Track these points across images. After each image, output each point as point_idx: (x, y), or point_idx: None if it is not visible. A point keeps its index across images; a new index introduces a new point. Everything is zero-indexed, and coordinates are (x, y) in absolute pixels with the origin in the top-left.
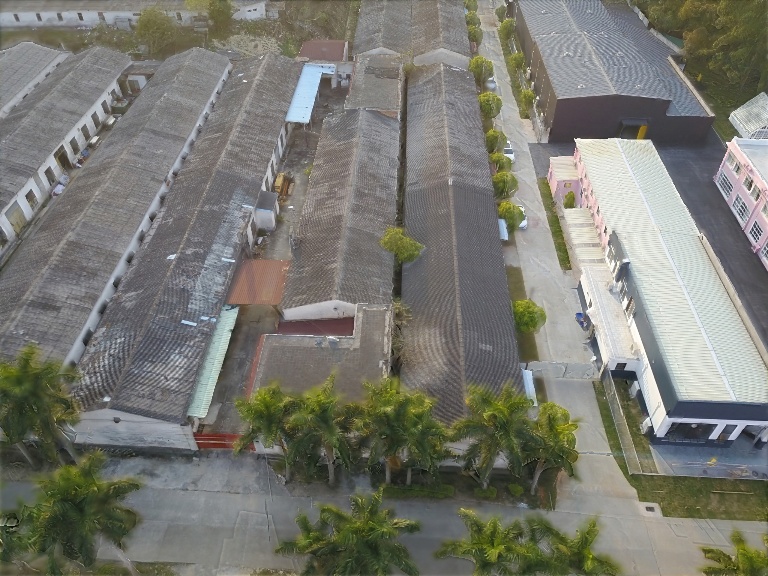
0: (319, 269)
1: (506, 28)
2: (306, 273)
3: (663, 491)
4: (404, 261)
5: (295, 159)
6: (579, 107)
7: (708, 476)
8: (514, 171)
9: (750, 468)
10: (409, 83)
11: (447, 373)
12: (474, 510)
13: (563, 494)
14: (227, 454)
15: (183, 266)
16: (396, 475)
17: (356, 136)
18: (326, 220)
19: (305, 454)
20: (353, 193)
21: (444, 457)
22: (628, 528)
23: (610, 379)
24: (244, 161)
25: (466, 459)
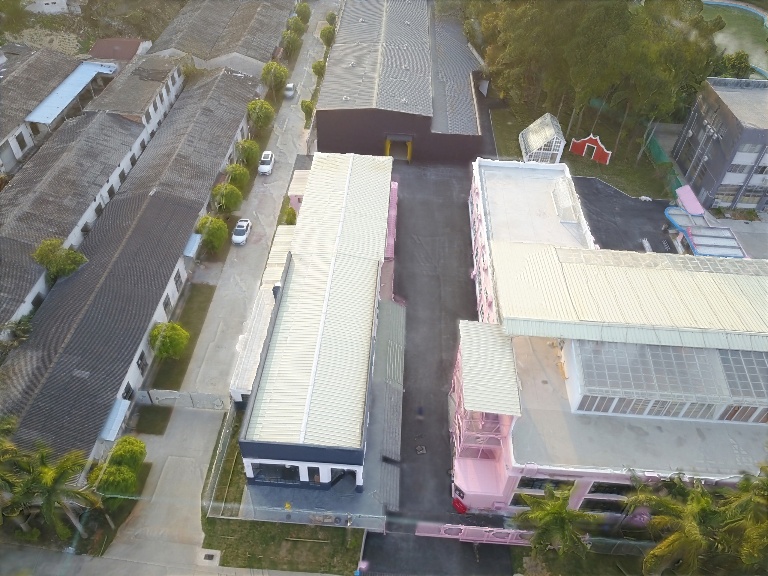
0: None
1: (325, 35)
2: None
3: (233, 537)
4: (58, 276)
5: None
6: (340, 119)
7: (288, 521)
8: (266, 183)
9: (337, 514)
10: (186, 87)
11: (17, 402)
12: (9, 554)
13: (121, 538)
14: None
15: None
16: None
17: (76, 140)
18: None
19: None
20: (32, 200)
21: None
22: None
23: (229, 411)
24: None
25: None
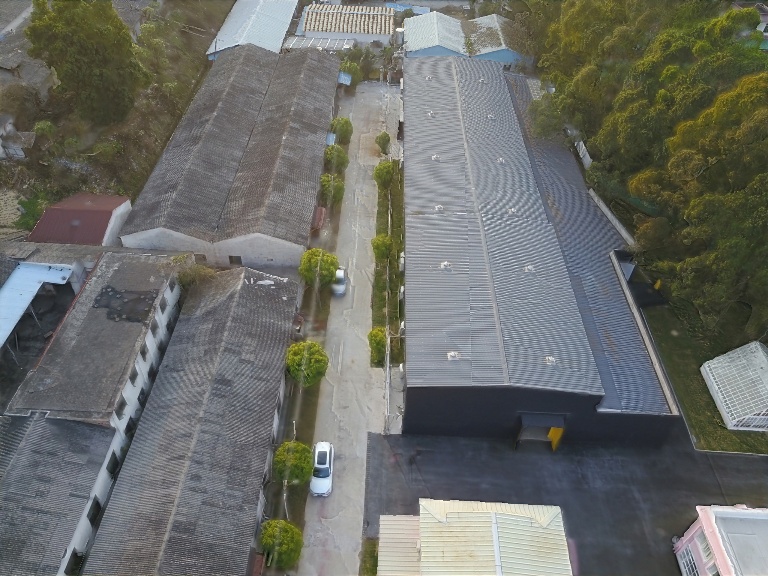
0: None
1: (381, 177)
2: None
3: None
4: None
5: None
6: (446, 397)
7: None
8: (325, 517)
9: None
10: (184, 308)
11: None
12: None
13: None
14: None
15: None
16: None
17: None
18: None
19: None
20: None
21: None
22: None
23: None
24: None
25: None
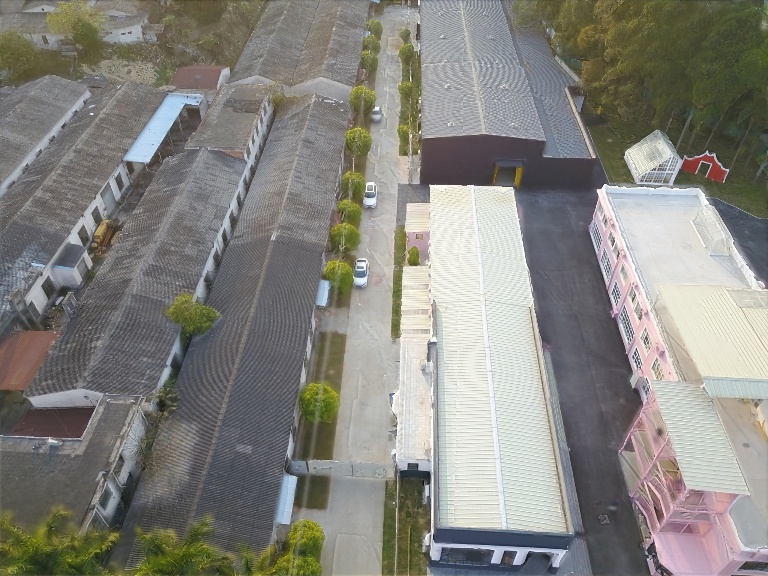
0: (82, 347)
1: (404, 53)
2: (68, 351)
3: None
4: (194, 334)
5: (134, 202)
6: (447, 147)
7: None
8: (373, 217)
9: None
10: (277, 116)
11: (185, 484)
12: None
13: None
14: None
15: None
16: None
17: (184, 181)
18: (114, 284)
19: None
20: (154, 251)
21: None
22: None
23: (397, 483)
24: (52, 210)
25: None
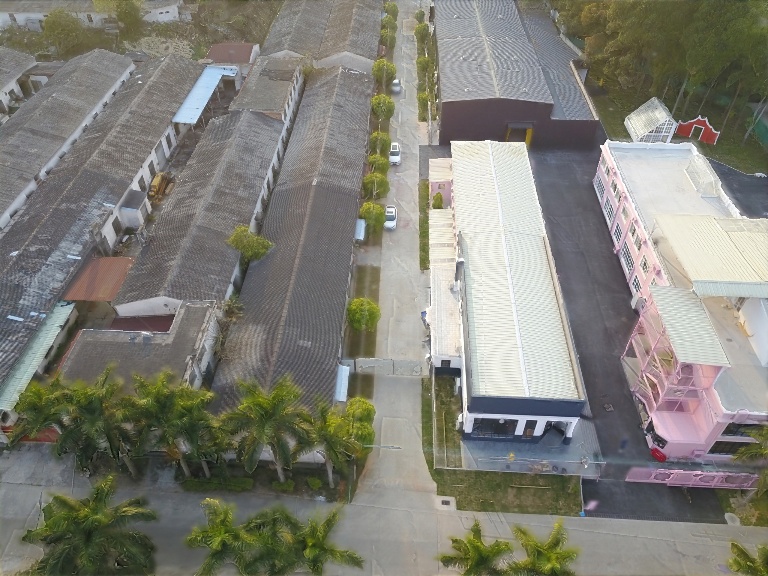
0: (158, 266)
1: (420, 32)
2: (145, 270)
3: (462, 485)
4: (251, 259)
5: (182, 159)
6: (464, 110)
7: (510, 471)
8: (398, 173)
9: (552, 463)
10: (307, 85)
11: (258, 368)
12: (270, 503)
13: (363, 488)
14: (39, 447)
15: (23, 263)
16: (194, 468)
17: (232, 137)
18: (179, 219)
19: (77, 445)
20: (212, 192)
21: (227, 450)
22: (418, 521)
23: None
24: (116, 160)
25: (237, 451)
